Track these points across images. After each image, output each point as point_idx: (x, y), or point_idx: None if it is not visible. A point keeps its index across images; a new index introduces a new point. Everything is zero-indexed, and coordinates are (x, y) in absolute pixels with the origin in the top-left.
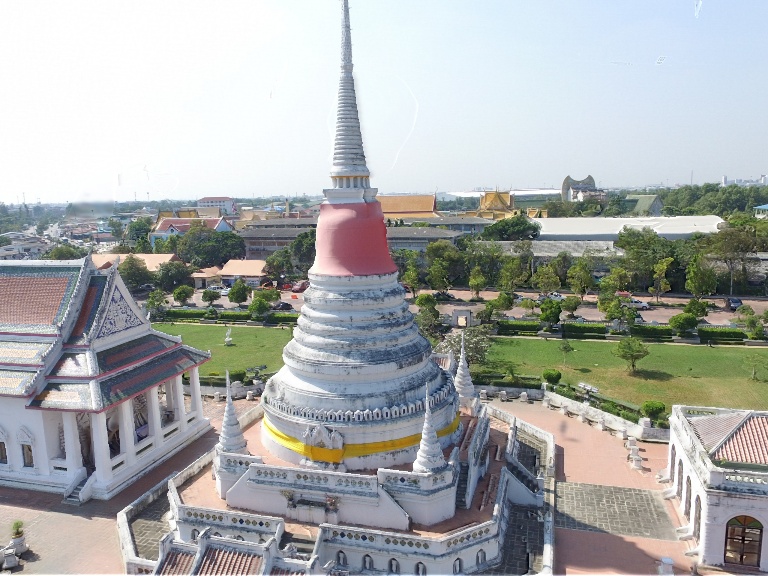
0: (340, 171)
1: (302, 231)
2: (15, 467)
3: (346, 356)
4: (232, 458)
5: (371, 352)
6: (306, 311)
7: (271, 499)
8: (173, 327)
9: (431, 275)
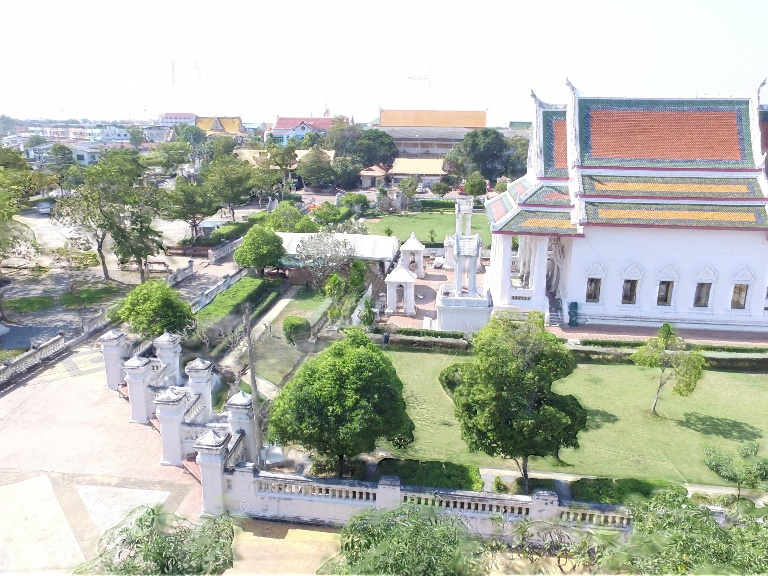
0: None
1: (447, 133)
2: (716, 310)
3: None
4: None
5: None
6: None
7: None
8: (450, 215)
9: None
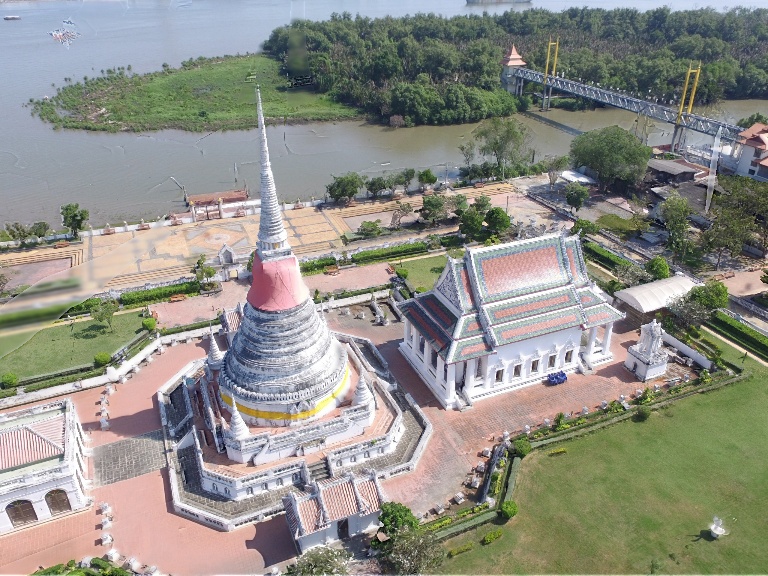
0: None
1: None
2: None
3: None
4: None
5: None
6: None
7: None
8: None
9: None
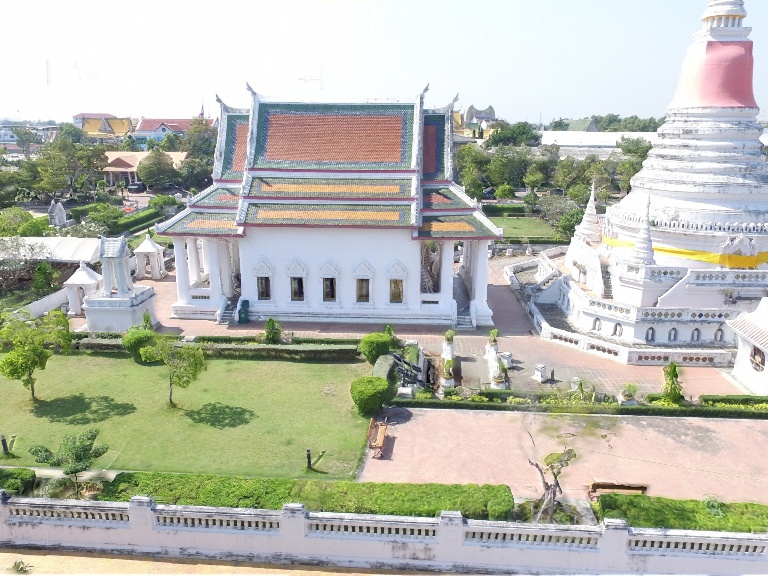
0: (731, 10)
1: None
2: (377, 304)
3: (744, 178)
4: (658, 269)
5: (760, 176)
6: (688, 142)
7: (707, 299)
8: None
9: (489, 172)
